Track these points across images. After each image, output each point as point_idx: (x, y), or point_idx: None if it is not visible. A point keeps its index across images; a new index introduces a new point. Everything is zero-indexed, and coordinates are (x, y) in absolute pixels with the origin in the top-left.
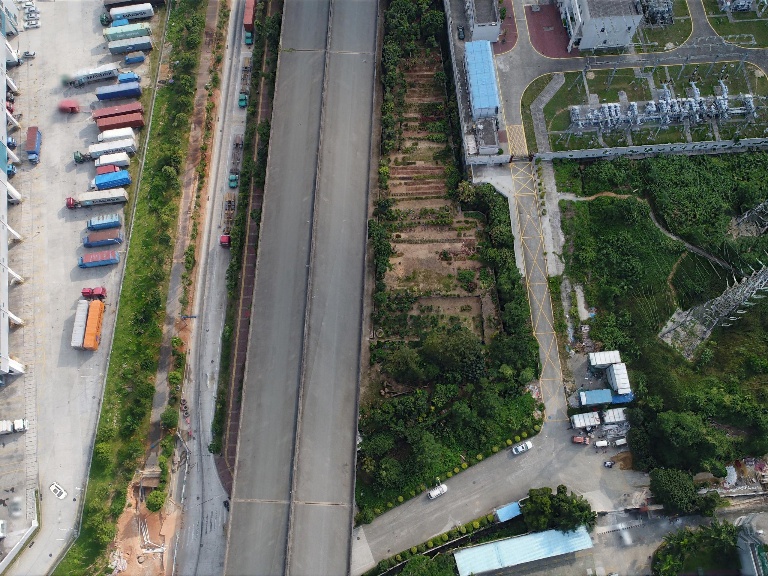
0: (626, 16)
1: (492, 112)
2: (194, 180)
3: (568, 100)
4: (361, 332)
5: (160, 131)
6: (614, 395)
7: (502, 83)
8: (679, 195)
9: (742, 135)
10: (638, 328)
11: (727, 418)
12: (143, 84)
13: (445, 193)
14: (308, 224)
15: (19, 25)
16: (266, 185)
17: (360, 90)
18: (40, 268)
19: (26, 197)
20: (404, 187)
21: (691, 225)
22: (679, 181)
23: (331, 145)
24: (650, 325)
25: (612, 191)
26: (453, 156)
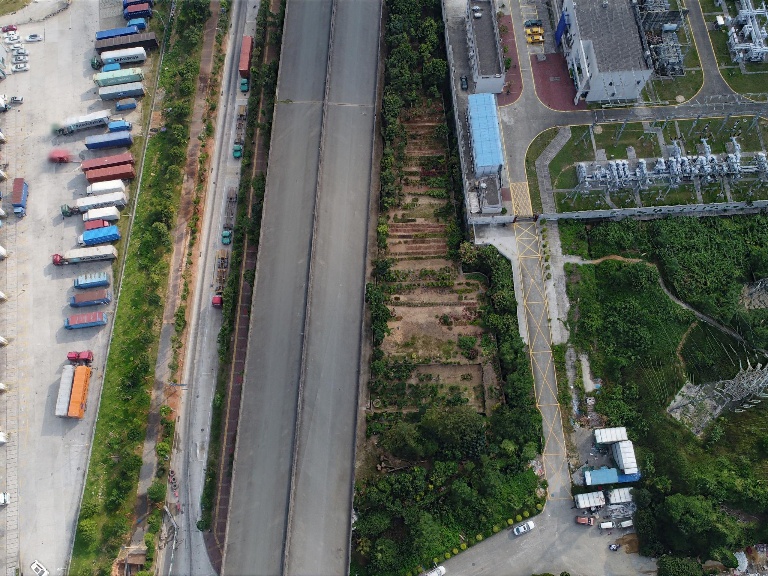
0: (636, 71)
1: (495, 169)
2: (186, 235)
3: (574, 156)
4: (357, 406)
5: (151, 182)
6: (620, 474)
7: (506, 137)
8: (689, 261)
9: (755, 195)
10: (645, 402)
11: (738, 503)
12: (134, 132)
13: (446, 253)
14: (303, 289)
15: (7, 68)
16: (260, 246)
17: (359, 145)
18: (24, 329)
19: (11, 252)
20: (403, 246)
21: (701, 293)
22: (689, 246)
23: (328, 204)
24: (658, 399)
25: (619, 254)
26: (455, 213)
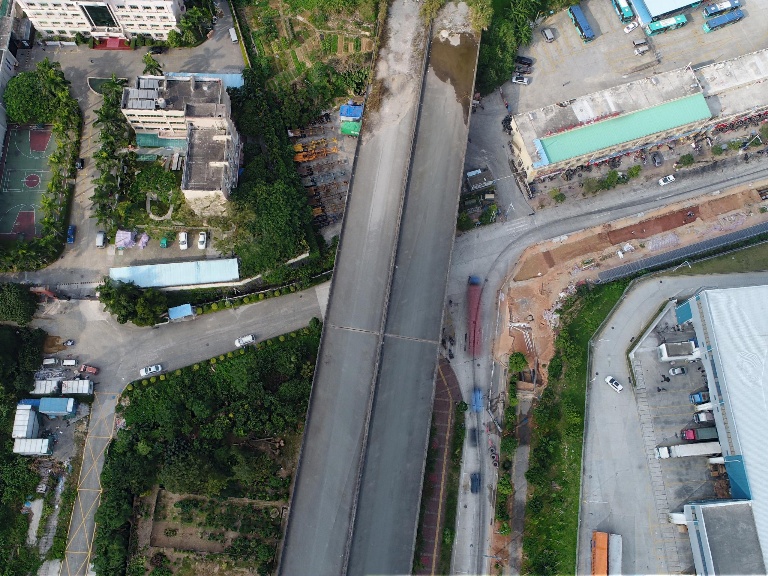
0: None
1: None
2: None
3: None
4: (293, 504)
5: None
6: (38, 407)
7: None
8: None
9: None
10: None
11: None
12: None
13: None
14: None
15: None
16: None
17: None
18: None
19: None
20: None
21: None
22: None
23: None
24: None
25: None
26: None
